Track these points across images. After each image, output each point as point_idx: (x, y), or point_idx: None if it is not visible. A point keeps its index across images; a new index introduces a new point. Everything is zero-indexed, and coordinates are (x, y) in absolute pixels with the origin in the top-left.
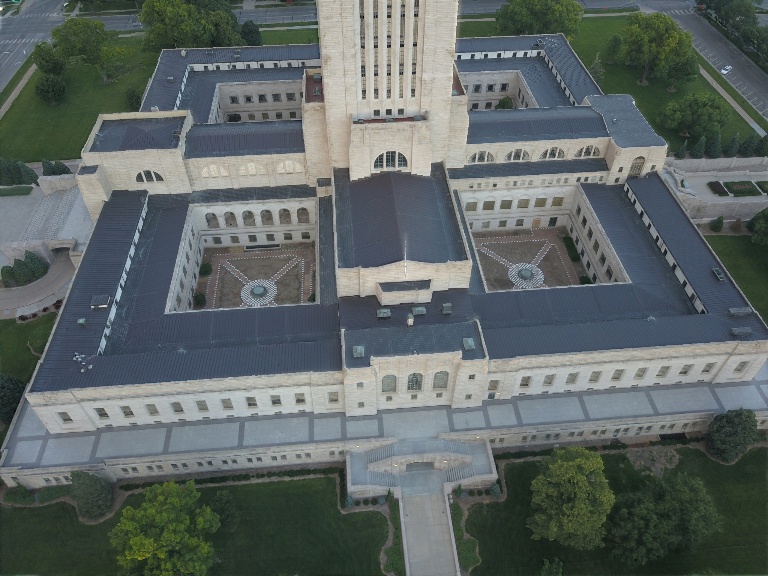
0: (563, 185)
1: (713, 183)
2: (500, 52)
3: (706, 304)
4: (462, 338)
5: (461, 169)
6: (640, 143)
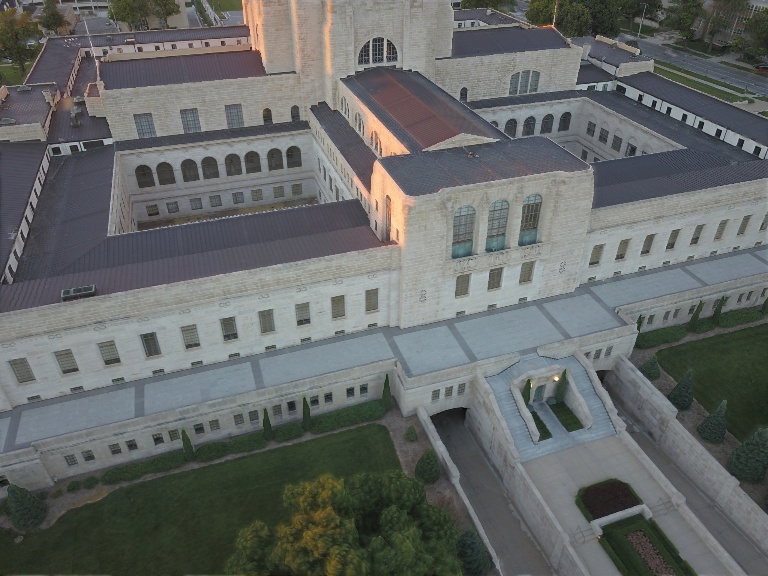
0: (349, 189)
1: (620, 486)
2: (721, 128)
3: (20, 282)
4: (20, 122)
5: (331, 111)
6: (404, 175)
